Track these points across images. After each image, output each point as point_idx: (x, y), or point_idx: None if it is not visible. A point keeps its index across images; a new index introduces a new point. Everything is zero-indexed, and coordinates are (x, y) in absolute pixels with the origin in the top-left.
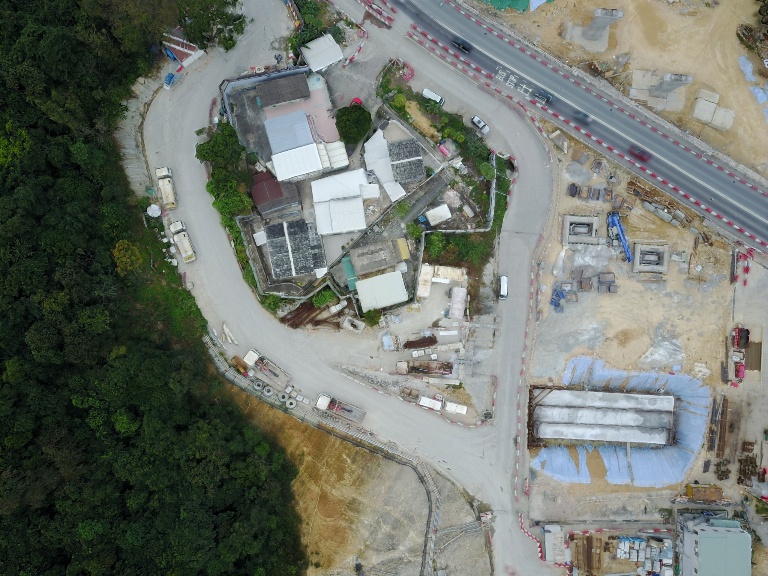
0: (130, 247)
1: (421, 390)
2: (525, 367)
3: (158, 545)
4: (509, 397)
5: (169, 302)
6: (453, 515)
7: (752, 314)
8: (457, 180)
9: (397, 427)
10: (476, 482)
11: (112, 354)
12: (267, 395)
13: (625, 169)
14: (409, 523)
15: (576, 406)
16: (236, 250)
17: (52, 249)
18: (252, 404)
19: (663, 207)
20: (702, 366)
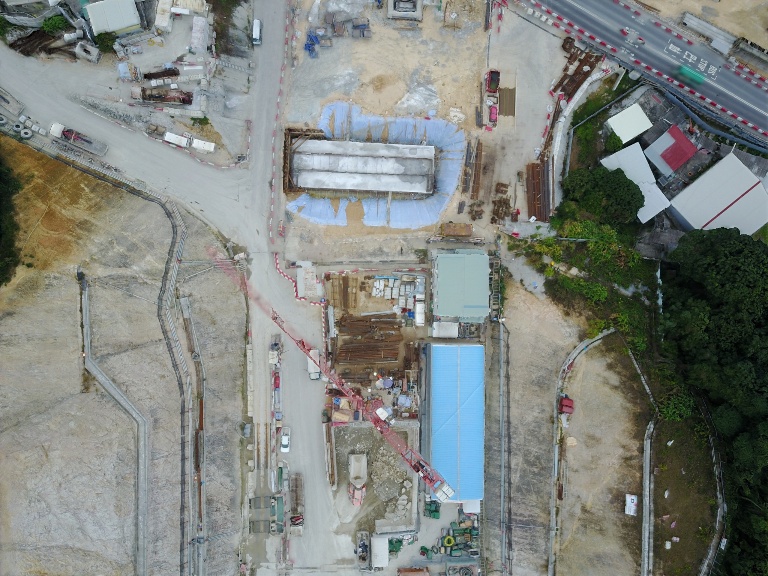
0: None
1: (168, 128)
2: (280, 111)
3: None
4: (265, 142)
5: None
6: (201, 250)
7: (506, 61)
8: None
9: (145, 165)
10: (231, 225)
11: None
12: None
13: None
14: (147, 248)
15: (335, 153)
16: None
17: None
18: None
19: None
20: (457, 111)
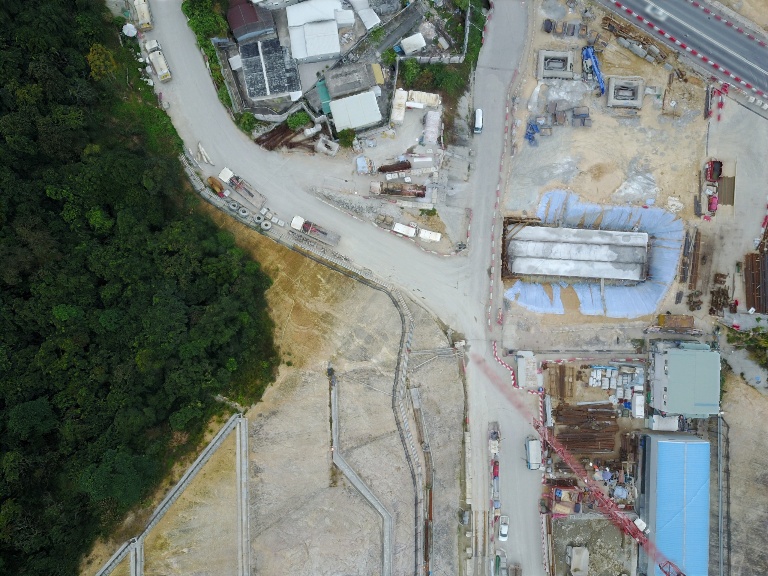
0: (104, 51)
1: (395, 217)
2: (499, 200)
3: (130, 329)
4: (483, 229)
5: (145, 119)
6: (427, 339)
7: (726, 149)
8: (432, 13)
9: (372, 254)
10: (450, 312)
11: (86, 150)
12: (242, 215)
13: (600, 5)
14: (382, 340)
15: (550, 241)
16: (211, 70)
17: (26, 46)
18: (227, 222)
19: (638, 43)
20: (675, 200)
